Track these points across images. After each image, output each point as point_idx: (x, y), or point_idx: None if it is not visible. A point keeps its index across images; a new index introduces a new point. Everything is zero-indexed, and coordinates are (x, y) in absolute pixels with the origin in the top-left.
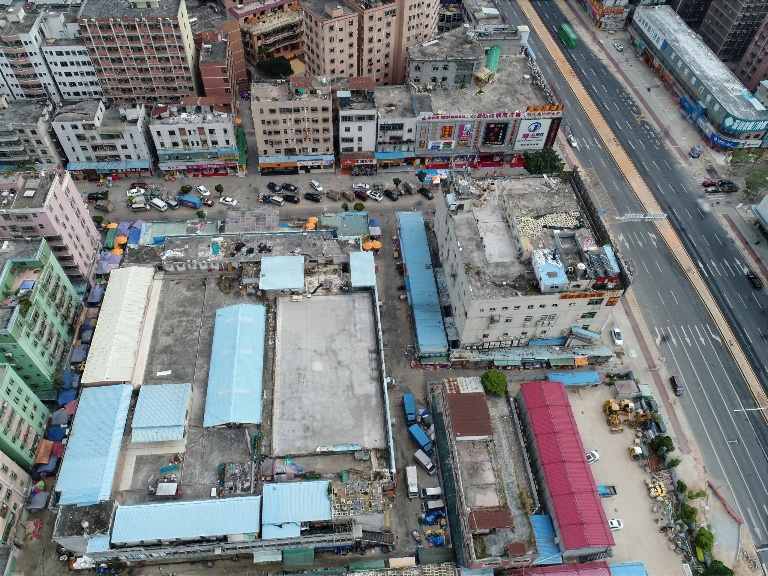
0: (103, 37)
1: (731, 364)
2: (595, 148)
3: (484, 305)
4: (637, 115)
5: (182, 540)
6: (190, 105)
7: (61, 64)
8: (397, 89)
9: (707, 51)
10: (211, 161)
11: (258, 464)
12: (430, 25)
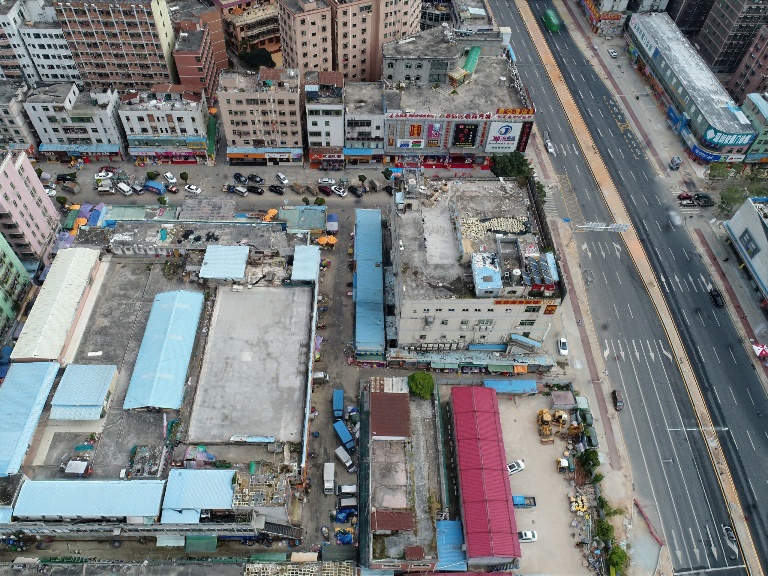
0: (79, 21)
1: (678, 382)
2: (572, 155)
3: (416, 306)
4: (621, 123)
5: (83, 518)
6: (160, 92)
7: (39, 46)
8: (370, 86)
9: (699, 61)
10: (180, 149)
11: (170, 449)
12: (409, 23)
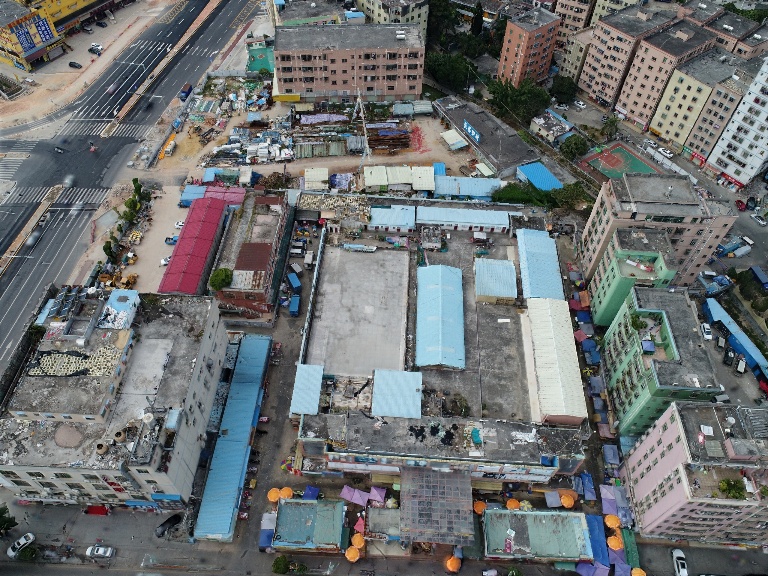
0: None
1: None
2: None
3: None
4: None
5: None
6: None
7: None
8: None
9: None
10: None
11: (419, 243)
12: None
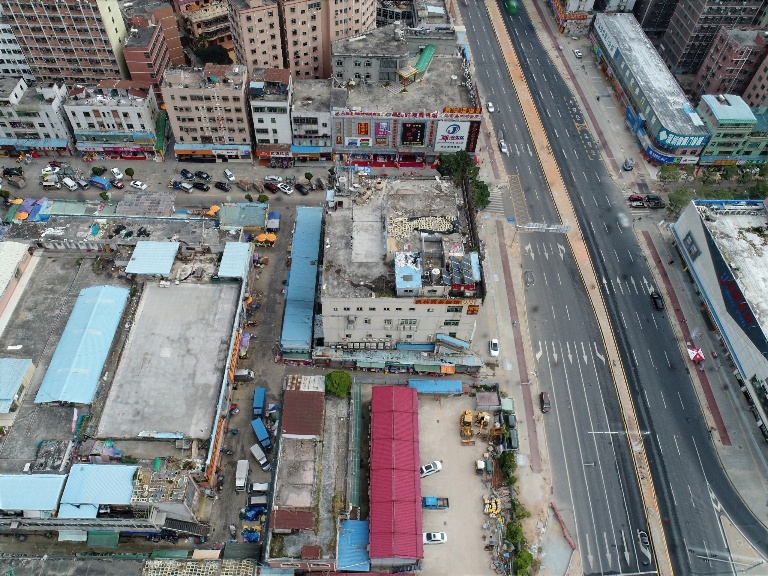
0: (25, 16)
1: (609, 385)
2: (525, 155)
3: (336, 304)
4: (579, 124)
5: None
6: (106, 88)
7: None
8: (320, 83)
9: (659, 62)
10: (127, 144)
11: (76, 444)
12: (361, 20)
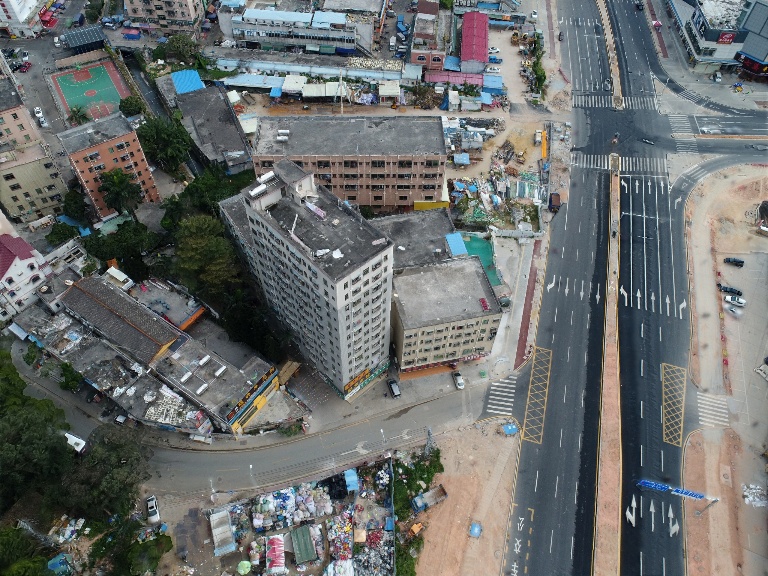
0: None
1: (601, 34)
2: None
3: None
4: None
5: None
6: None
7: None
8: None
9: None
10: None
11: (315, 8)
12: None
